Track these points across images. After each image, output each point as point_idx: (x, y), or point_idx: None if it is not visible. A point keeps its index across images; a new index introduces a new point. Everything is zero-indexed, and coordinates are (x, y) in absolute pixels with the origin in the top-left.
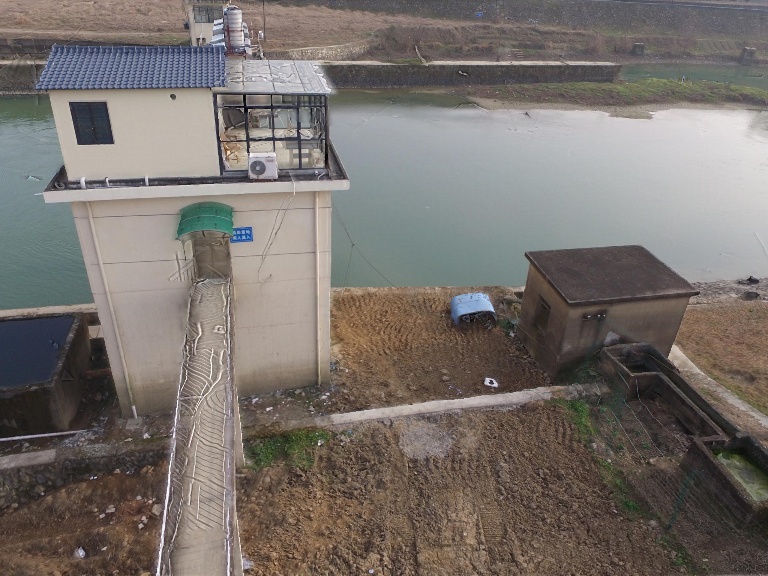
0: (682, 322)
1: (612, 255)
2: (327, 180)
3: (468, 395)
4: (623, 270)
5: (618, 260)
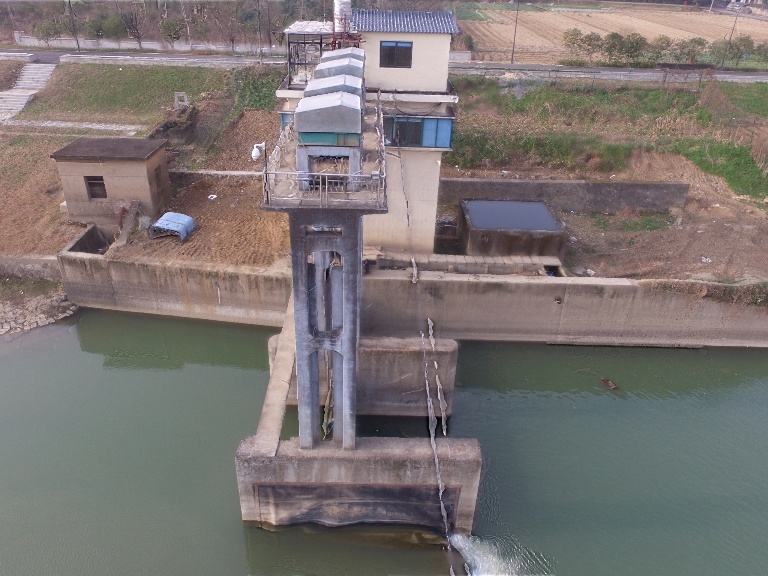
0: None
1: (89, 151)
2: None
3: (232, 194)
4: (103, 145)
5: (92, 149)
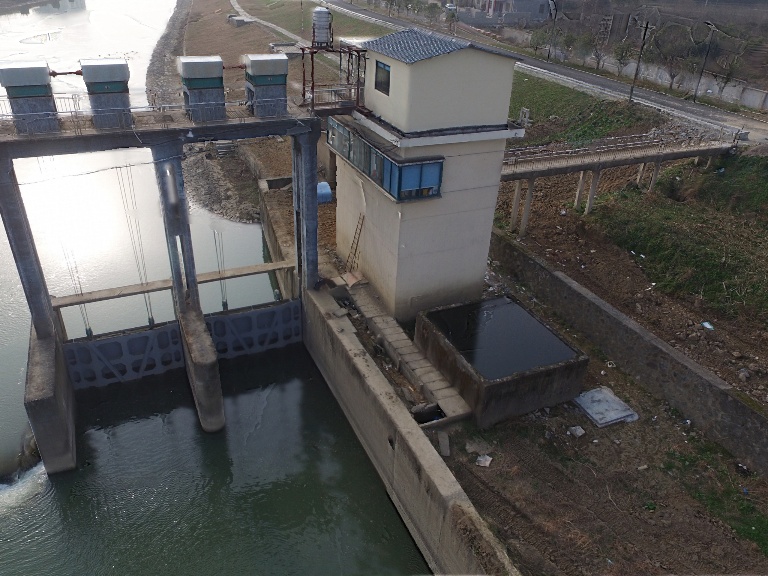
0: (282, 160)
1: None
2: None
3: None
4: None
5: None
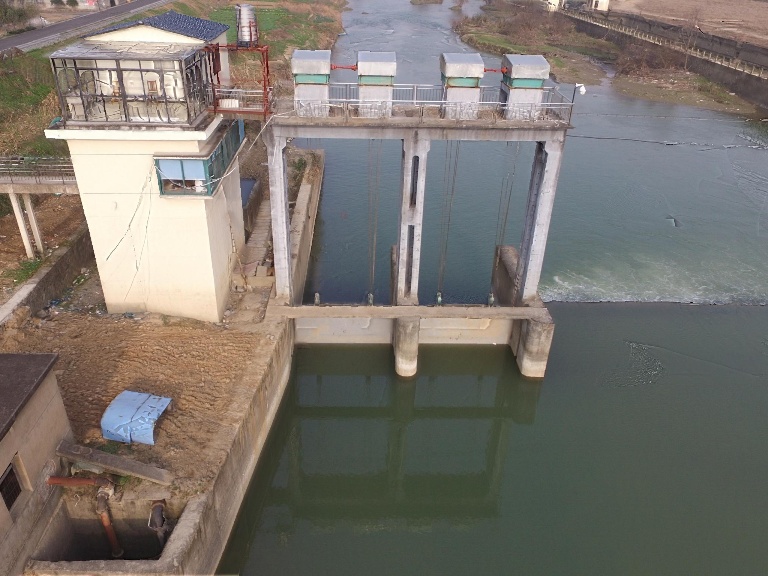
0: None
1: None
2: (53, 125)
3: None
4: None
5: None
